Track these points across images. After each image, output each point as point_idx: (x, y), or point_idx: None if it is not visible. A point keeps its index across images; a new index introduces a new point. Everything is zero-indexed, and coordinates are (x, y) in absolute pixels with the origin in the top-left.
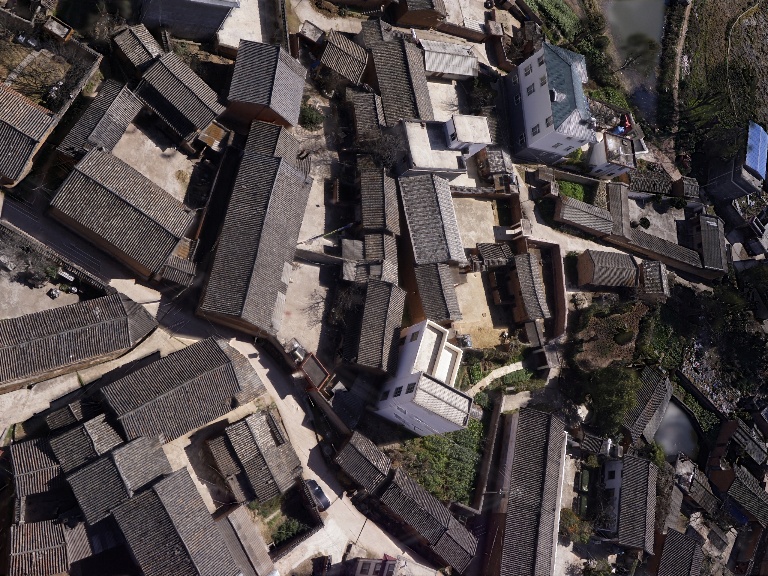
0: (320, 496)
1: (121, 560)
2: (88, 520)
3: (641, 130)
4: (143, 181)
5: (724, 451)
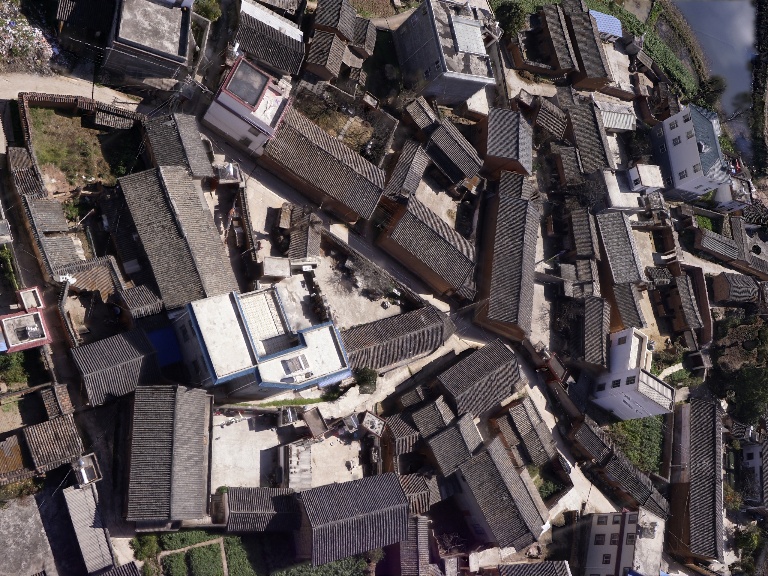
0: None
1: (450, 507)
2: (443, 473)
3: (749, 172)
4: None
5: None
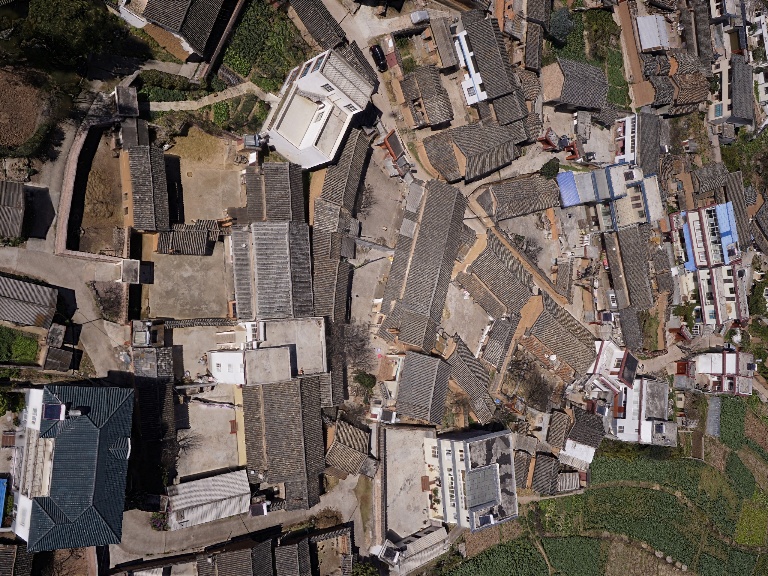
0: (383, 56)
1: None
2: (521, 89)
3: None
4: None
5: None
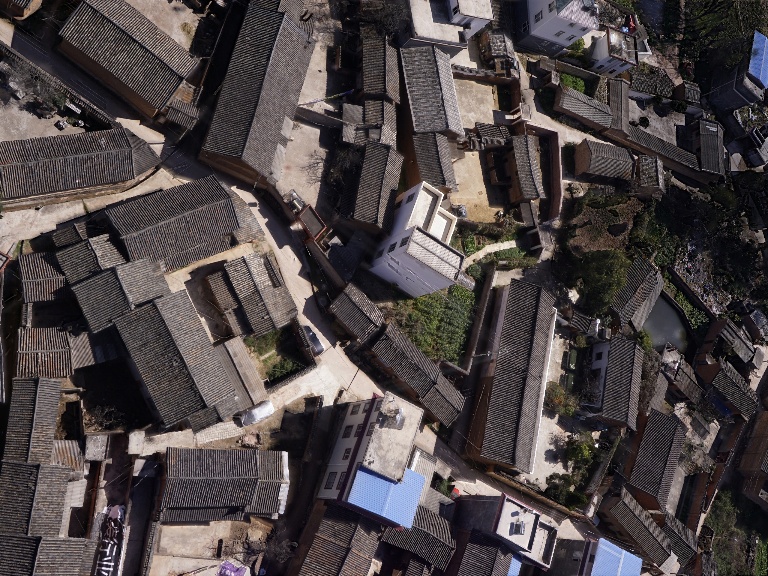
0: (314, 341)
1: (122, 376)
2: (91, 328)
3: (645, 31)
4: (149, 24)
5: (711, 347)
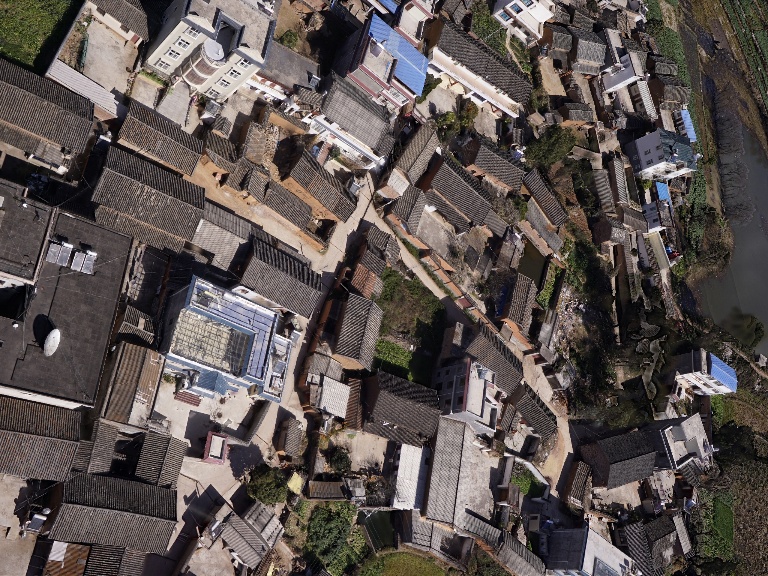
0: None
1: None
2: None
3: None
4: None
5: None
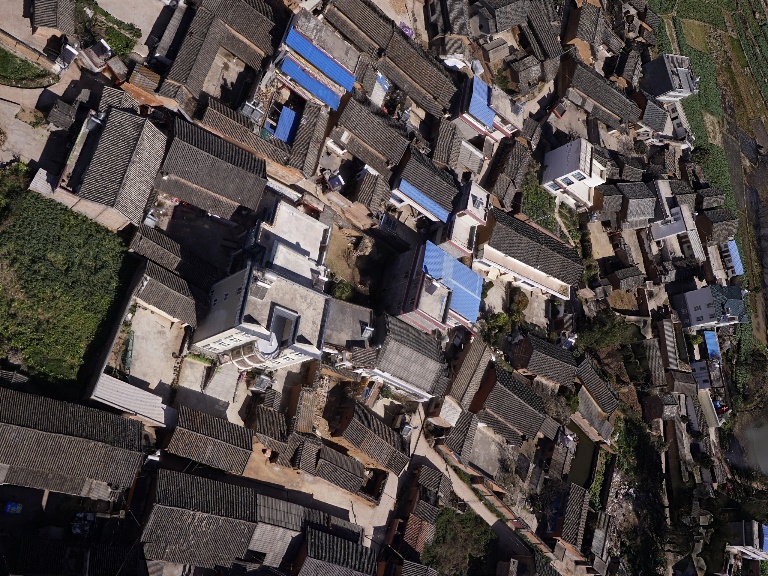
0: None
1: None
2: None
3: None
4: None
5: None
